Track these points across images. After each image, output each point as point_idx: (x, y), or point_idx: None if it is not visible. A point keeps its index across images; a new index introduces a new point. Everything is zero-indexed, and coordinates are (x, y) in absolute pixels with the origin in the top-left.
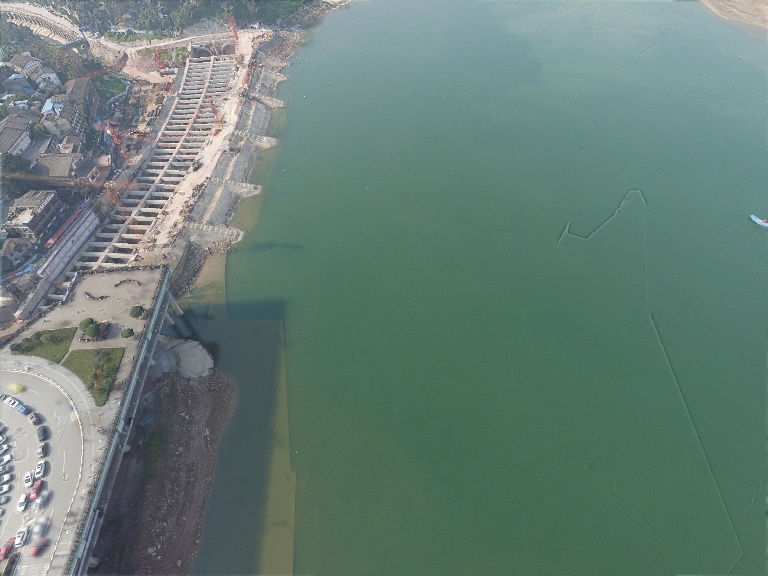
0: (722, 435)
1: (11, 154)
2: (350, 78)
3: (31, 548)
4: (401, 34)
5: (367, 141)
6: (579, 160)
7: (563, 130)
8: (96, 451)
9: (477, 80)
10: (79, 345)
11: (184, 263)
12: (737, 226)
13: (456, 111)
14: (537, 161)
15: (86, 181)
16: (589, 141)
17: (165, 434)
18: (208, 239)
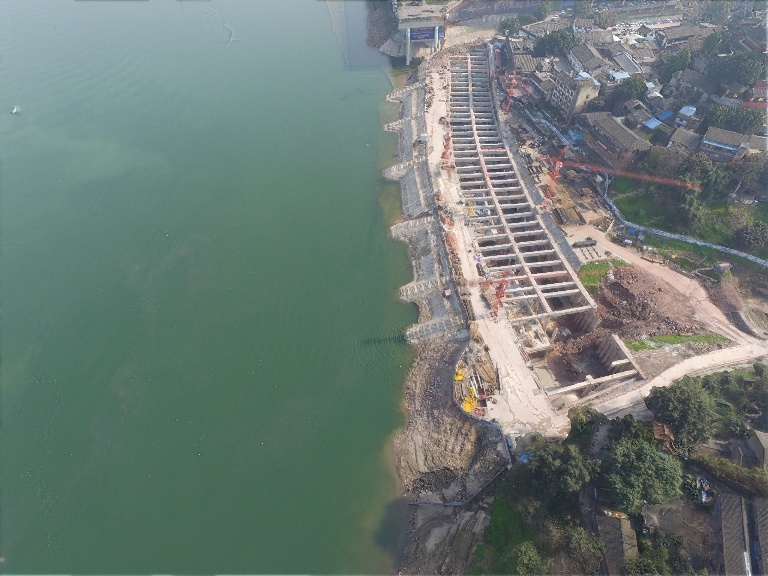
0: (156, 47)
1: (558, 42)
2: (295, 291)
3: None
4: (157, 463)
5: (283, 175)
6: (83, 163)
7: (61, 198)
8: None
9: (101, 266)
10: None
11: None
12: (28, 114)
13: (165, 215)
14: (124, 157)
15: None
16: (49, 185)
17: None
18: None
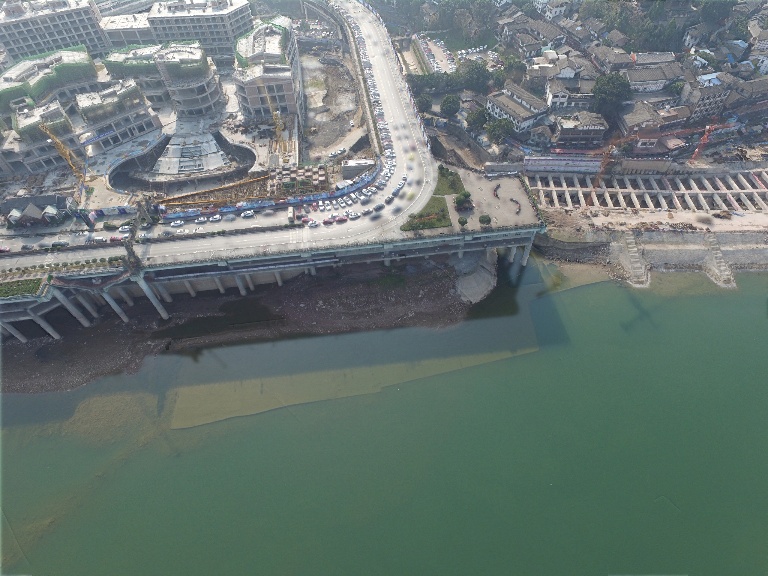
0: None
1: (629, 84)
2: None
3: (307, 230)
4: None
5: None
6: None
7: None
8: (366, 238)
9: None
10: (450, 199)
11: (580, 247)
12: None
13: None
14: None
15: (637, 142)
16: None
17: (402, 284)
18: (621, 258)
